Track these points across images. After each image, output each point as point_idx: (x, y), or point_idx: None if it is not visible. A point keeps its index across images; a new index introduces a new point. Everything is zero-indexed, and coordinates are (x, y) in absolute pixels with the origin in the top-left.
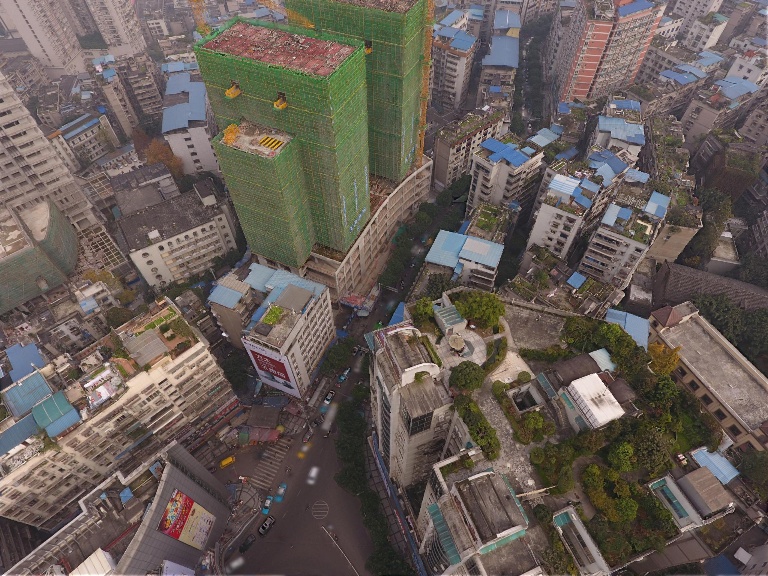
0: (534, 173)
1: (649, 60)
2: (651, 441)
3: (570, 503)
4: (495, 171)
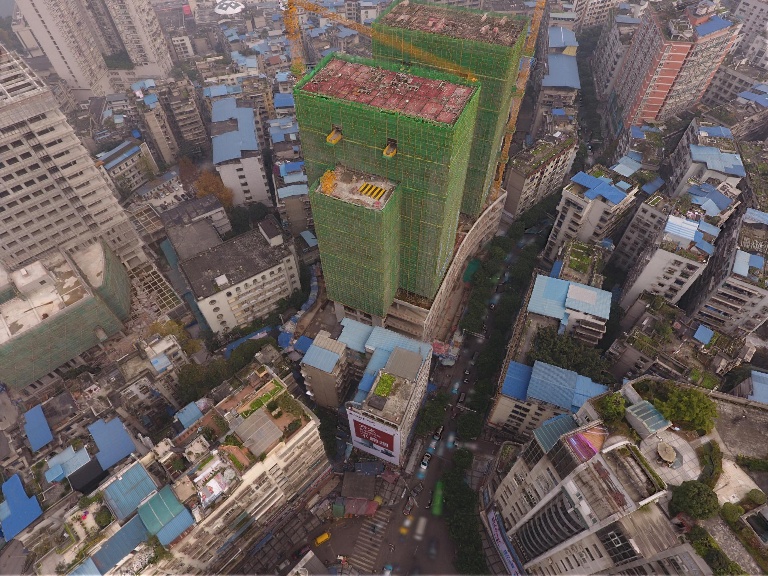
0: (626, 208)
1: (716, 79)
2: None
3: None
4: (588, 208)
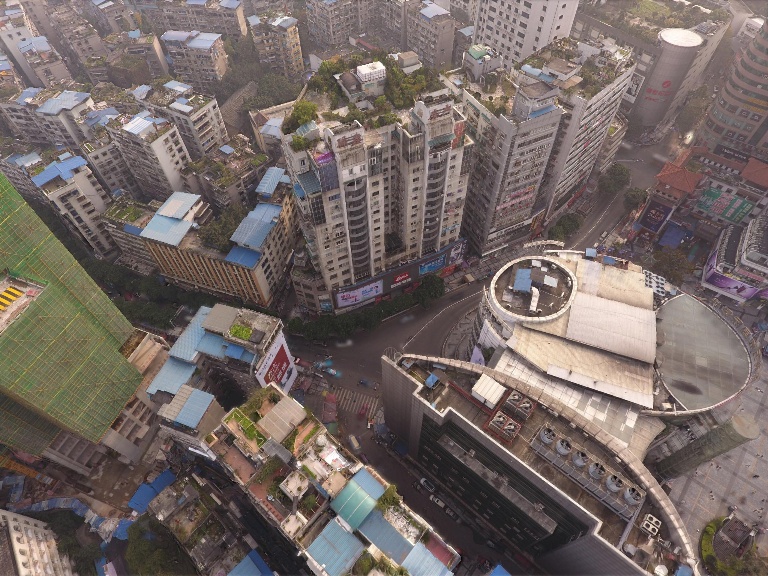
0: None
1: None
2: (391, 61)
3: (420, 98)
4: None
